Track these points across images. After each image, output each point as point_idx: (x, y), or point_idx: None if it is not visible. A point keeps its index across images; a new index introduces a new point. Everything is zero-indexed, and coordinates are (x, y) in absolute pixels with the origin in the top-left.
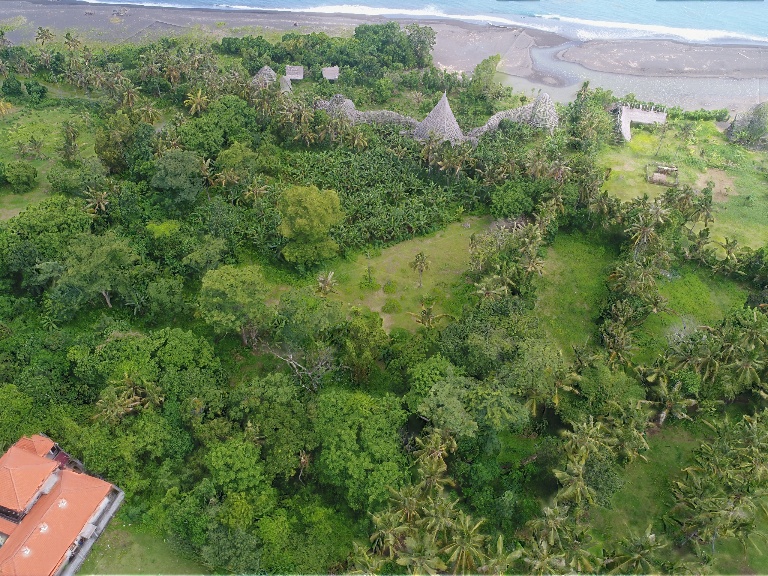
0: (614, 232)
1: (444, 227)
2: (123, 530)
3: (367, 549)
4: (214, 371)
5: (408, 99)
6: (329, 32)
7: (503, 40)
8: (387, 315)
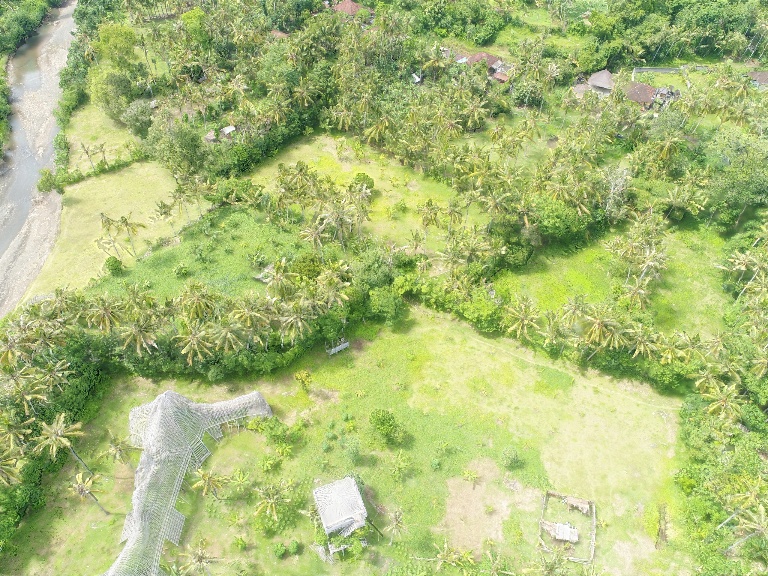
0: None
1: None
2: None
3: None
4: None
5: None
6: None
7: None
8: None
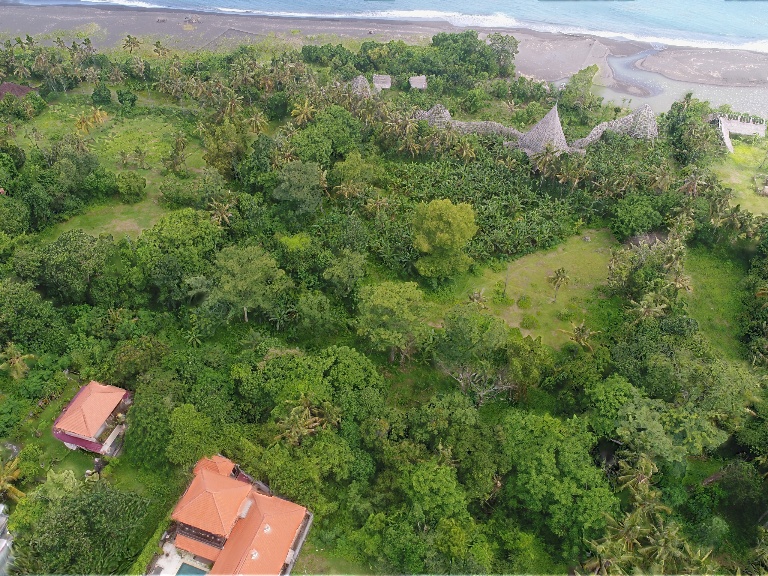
0: (743, 247)
1: (564, 240)
2: (317, 555)
3: (565, 575)
4: (379, 390)
5: (498, 109)
6: (405, 40)
7: (579, 49)
8: (527, 331)
